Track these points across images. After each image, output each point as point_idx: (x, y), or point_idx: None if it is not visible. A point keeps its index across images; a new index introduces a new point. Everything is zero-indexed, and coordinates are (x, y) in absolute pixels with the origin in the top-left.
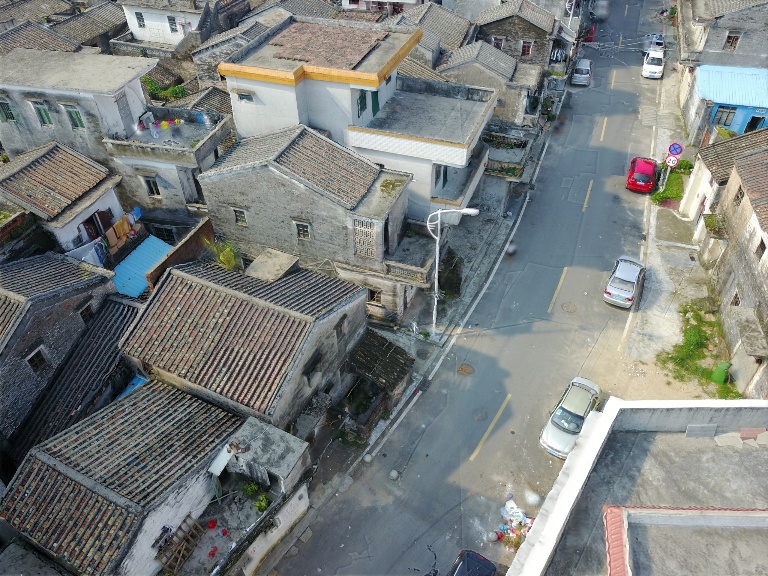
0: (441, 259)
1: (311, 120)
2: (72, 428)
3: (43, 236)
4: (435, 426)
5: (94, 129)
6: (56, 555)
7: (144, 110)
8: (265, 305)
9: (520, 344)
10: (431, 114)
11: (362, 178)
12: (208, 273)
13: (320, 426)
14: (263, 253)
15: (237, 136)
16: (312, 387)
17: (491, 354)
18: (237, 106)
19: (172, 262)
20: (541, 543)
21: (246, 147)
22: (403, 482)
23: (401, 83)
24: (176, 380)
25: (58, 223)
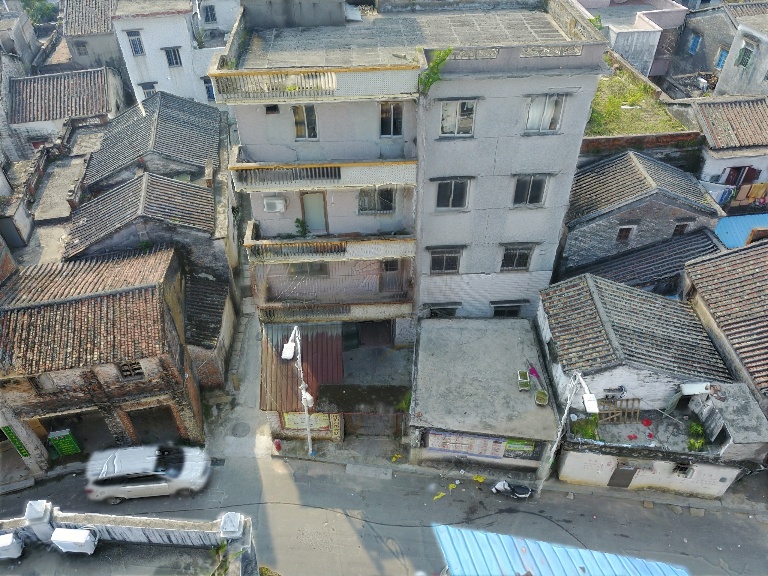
0: None
1: None
2: (617, 284)
3: (696, 159)
4: None
5: None
6: (550, 341)
7: None
8: None
9: None
10: None
11: None
12: None
13: None
14: None
15: None
16: None
17: None
18: None
19: None
20: None
21: None
22: None
23: None
24: (706, 317)
25: (717, 154)
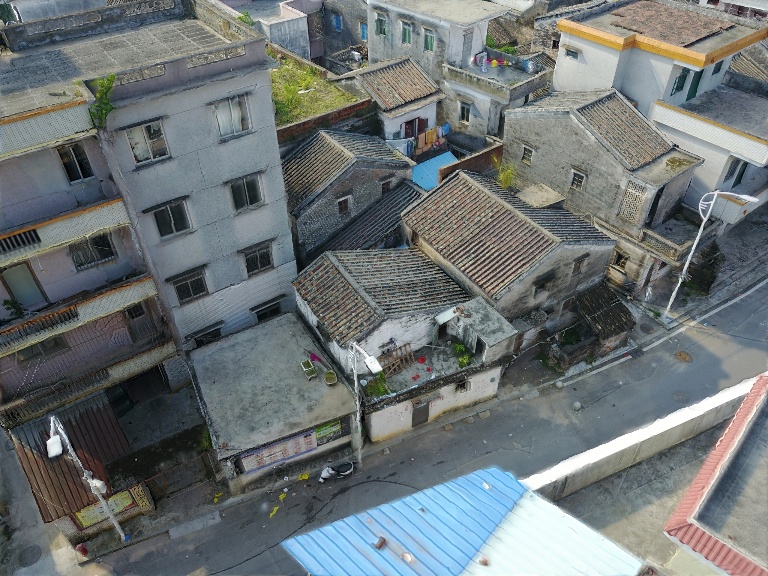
0: (701, 247)
1: (624, 88)
2: (354, 251)
3: (376, 123)
4: (632, 387)
5: (440, 54)
6: (318, 325)
7: (482, 50)
8: (524, 218)
9: (753, 358)
10: (749, 112)
11: (652, 148)
12: (487, 184)
13: (529, 340)
14: (536, 185)
15: (551, 88)
16: (536, 301)
17: (717, 354)
18: (561, 61)
19: (462, 167)
20: (690, 409)
21: (555, 98)
22: (583, 415)
23: (729, 78)
24: (433, 254)
25: (391, 115)
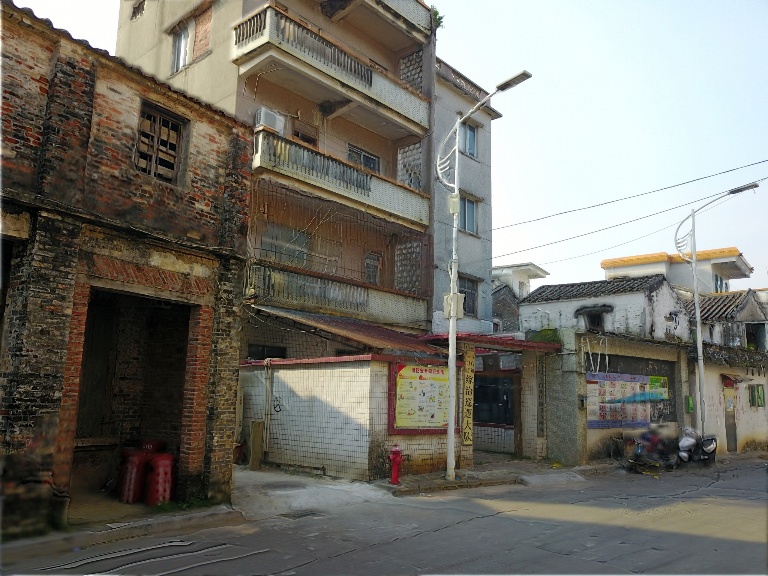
0: None
1: None
2: None
3: None
4: None
5: None
6: None
7: None
8: None
9: None
10: None
11: None
12: None
13: None
14: None
15: None
16: None
17: None
18: None
19: None
20: None
21: None
22: None
23: None
24: None
25: None
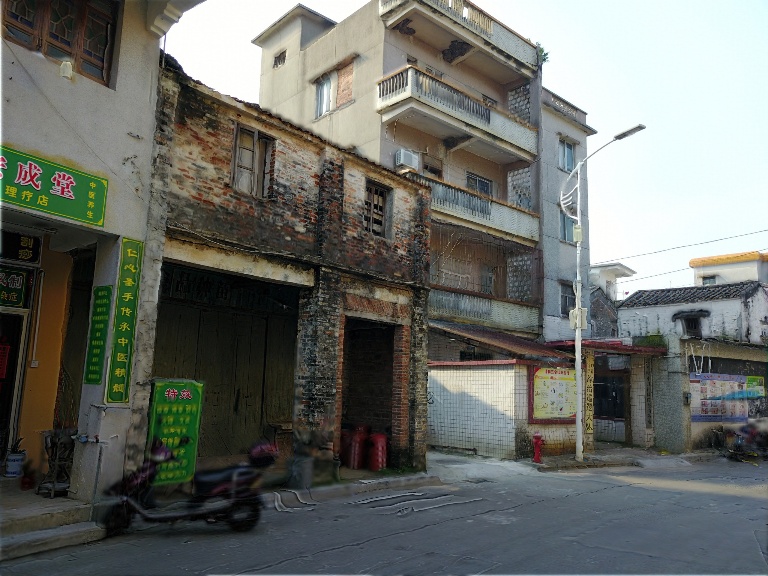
0: None
1: None
2: None
3: None
4: None
5: None
6: None
7: None
8: None
9: None
10: None
11: None
12: None
13: None
14: None
15: None
16: None
17: None
18: None
19: None
20: None
21: None
22: None
23: None
24: None
25: None
